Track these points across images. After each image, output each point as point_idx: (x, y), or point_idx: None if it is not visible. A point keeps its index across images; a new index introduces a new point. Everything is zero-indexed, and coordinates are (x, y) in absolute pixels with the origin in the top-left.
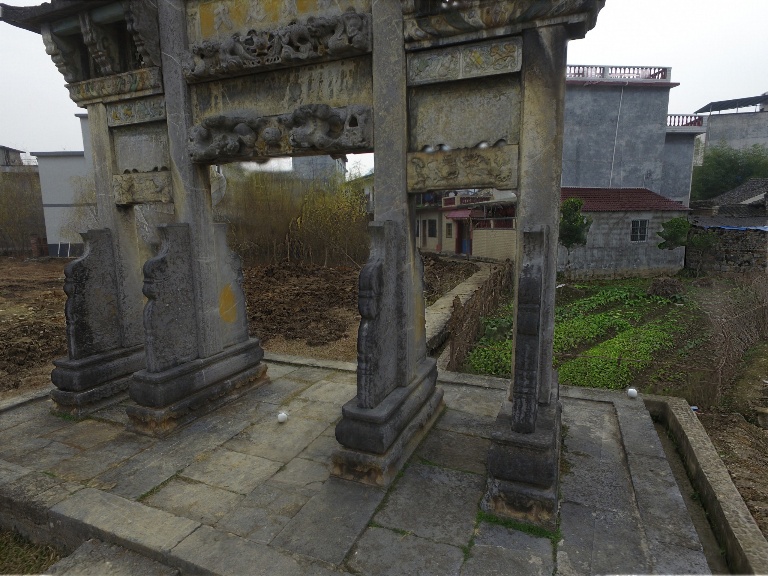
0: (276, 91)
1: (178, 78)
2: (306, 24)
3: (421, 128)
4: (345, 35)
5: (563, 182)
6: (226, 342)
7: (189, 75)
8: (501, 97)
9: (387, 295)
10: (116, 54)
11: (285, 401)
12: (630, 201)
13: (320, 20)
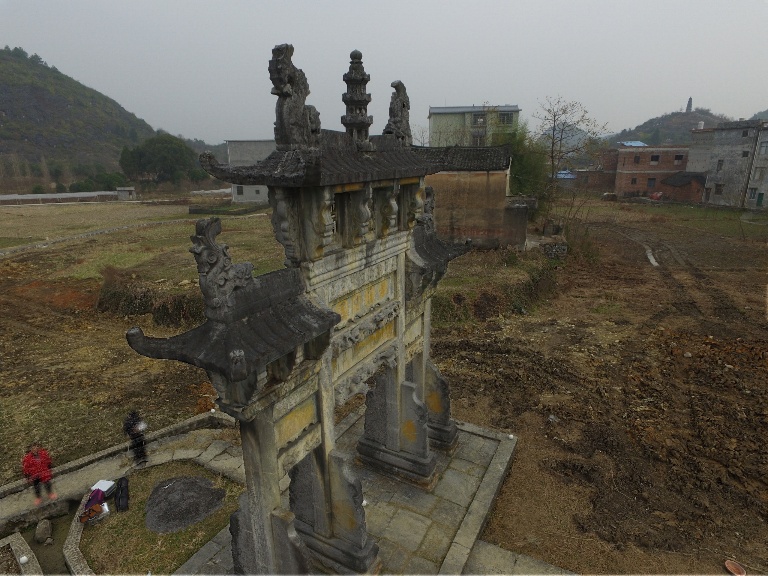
0: None
1: None
2: None
3: None
4: None
5: None
6: (407, 449)
7: None
8: None
9: (303, 478)
10: None
11: (393, 503)
12: None
13: None
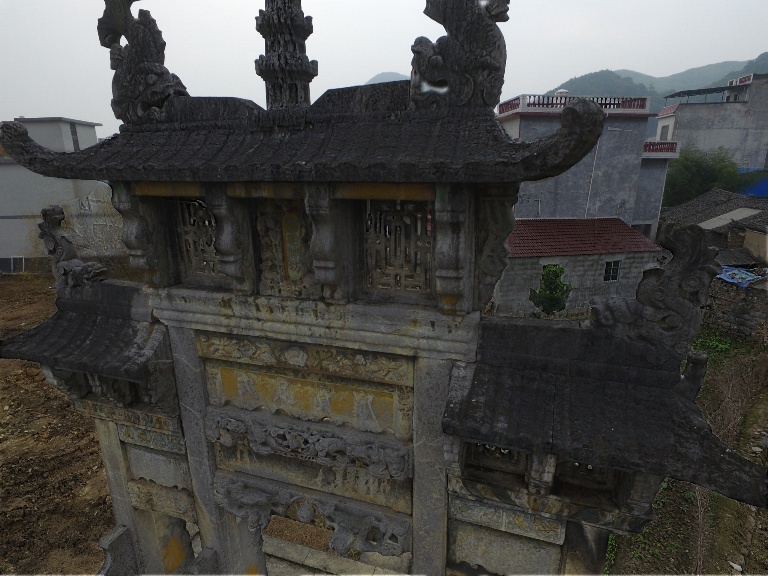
0: (308, 469)
1: (200, 431)
2: (341, 424)
3: (460, 547)
4: (387, 471)
5: (541, 214)
6: None
7: (214, 442)
8: (541, 550)
9: None
10: (126, 387)
11: None
12: (605, 239)
13: (361, 454)
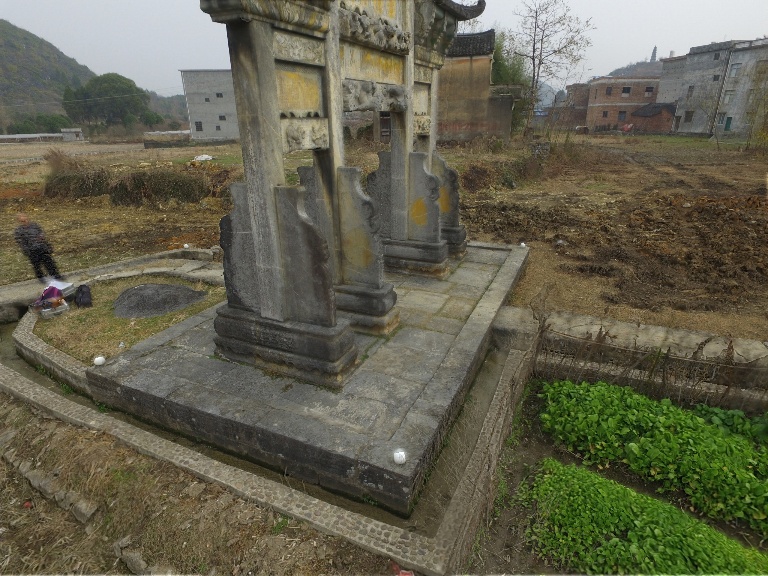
0: None
1: None
2: None
3: None
4: None
5: None
6: (416, 237)
7: None
8: None
9: None
10: None
11: (404, 287)
12: None
13: None
